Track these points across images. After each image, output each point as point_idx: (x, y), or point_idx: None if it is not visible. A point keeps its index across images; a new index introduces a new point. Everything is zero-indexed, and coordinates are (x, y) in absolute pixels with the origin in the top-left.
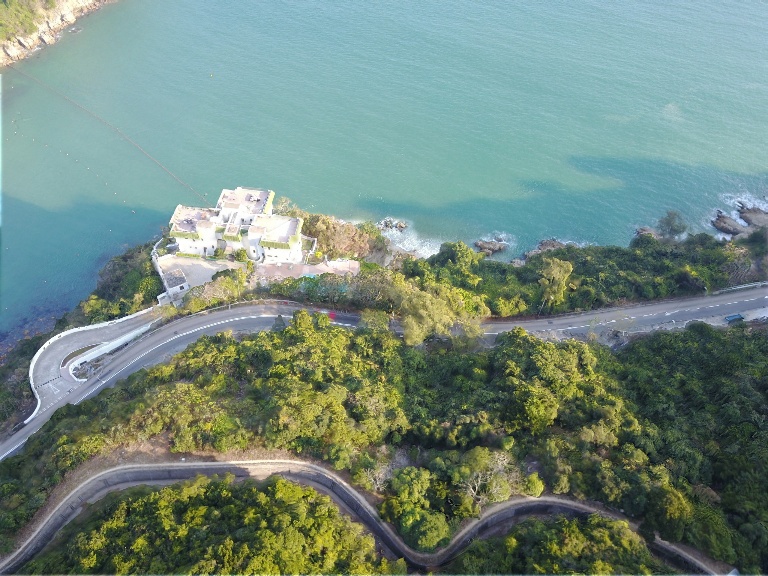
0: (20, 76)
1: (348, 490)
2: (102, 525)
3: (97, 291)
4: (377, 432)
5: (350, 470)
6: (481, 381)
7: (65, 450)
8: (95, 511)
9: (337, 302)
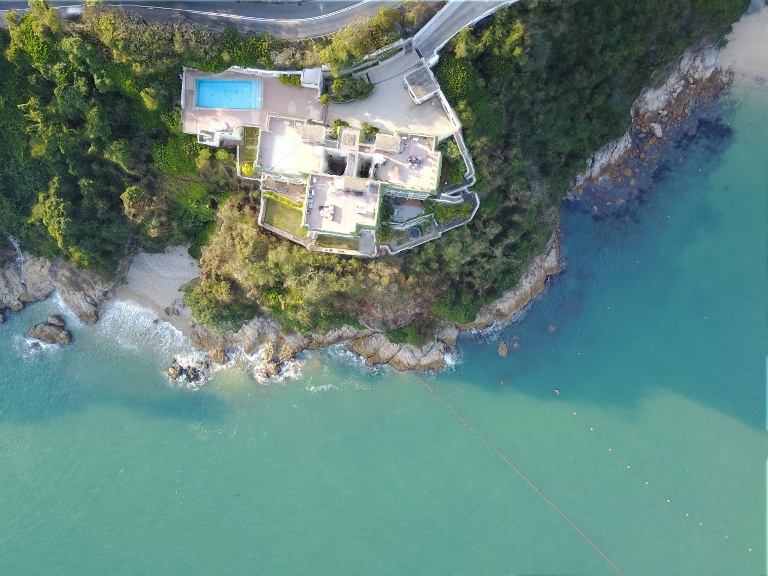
0: None
1: None
2: None
3: (552, 190)
4: None
5: None
6: None
7: None
8: None
9: None
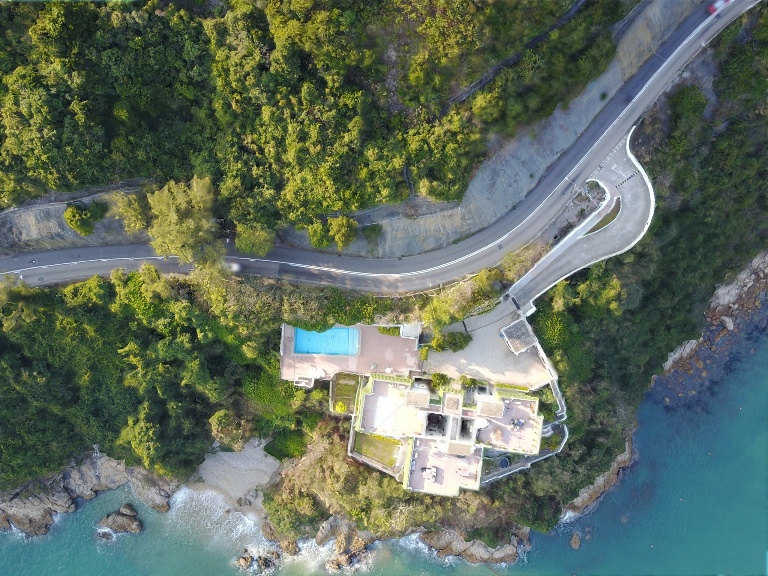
0: None
1: None
2: None
3: (631, 400)
4: None
5: None
6: (120, 100)
7: None
8: None
9: None
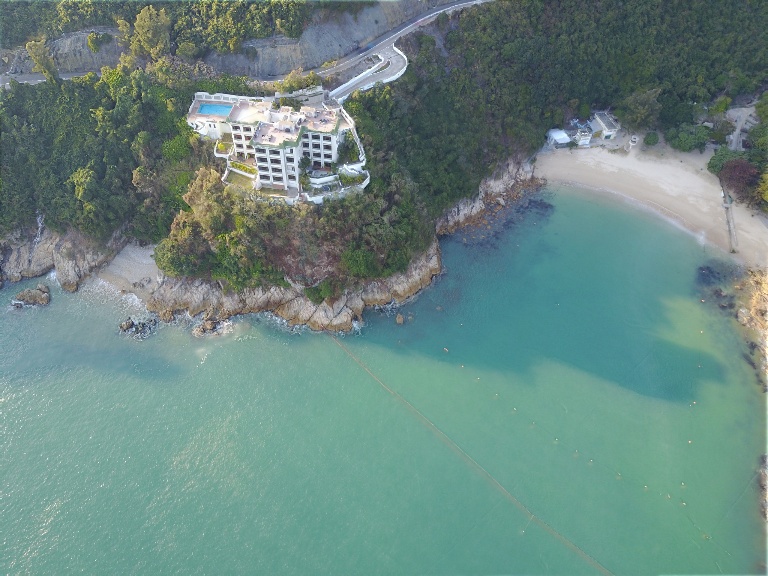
0: None
1: None
2: None
3: None
4: None
5: None
6: None
7: None
8: None
9: None
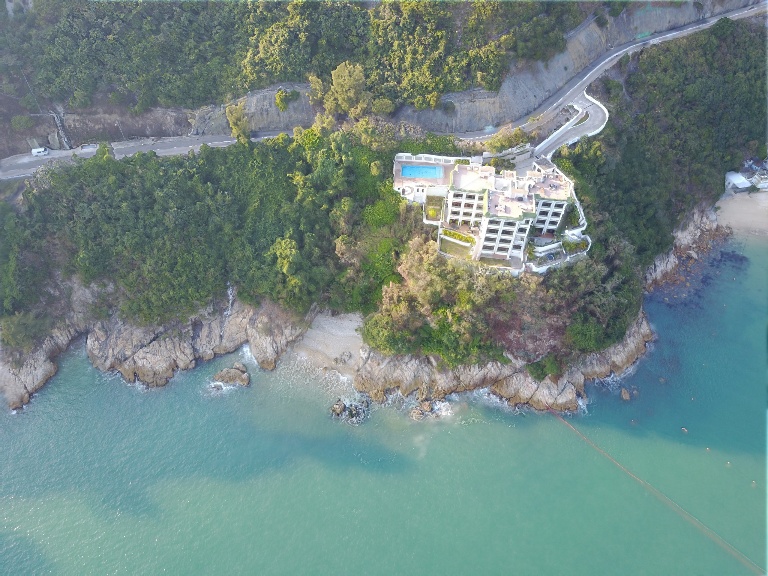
0: None
1: None
2: None
3: None
4: None
5: None
6: None
7: None
8: None
9: None
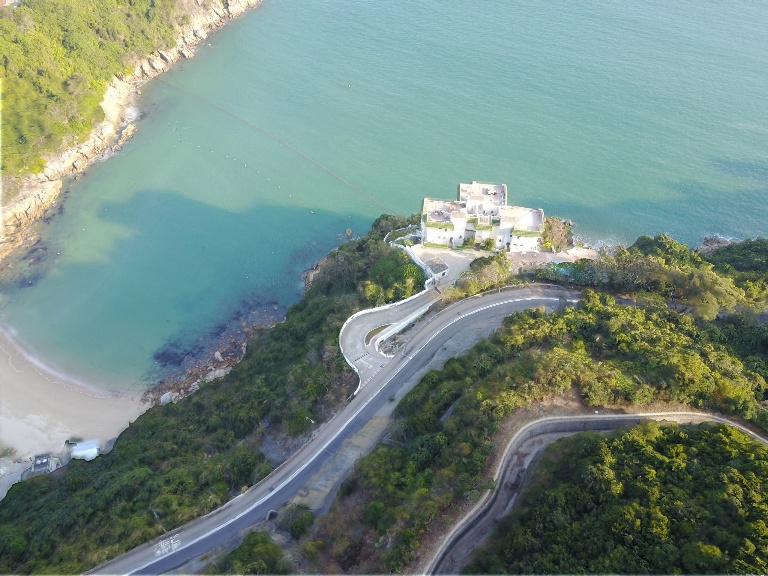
0: (169, 87)
1: (757, 438)
2: (604, 459)
3: (321, 283)
4: (750, 389)
5: (754, 420)
6: None
7: (490, 404)
8: (566, 452)
9: (597, 285)
